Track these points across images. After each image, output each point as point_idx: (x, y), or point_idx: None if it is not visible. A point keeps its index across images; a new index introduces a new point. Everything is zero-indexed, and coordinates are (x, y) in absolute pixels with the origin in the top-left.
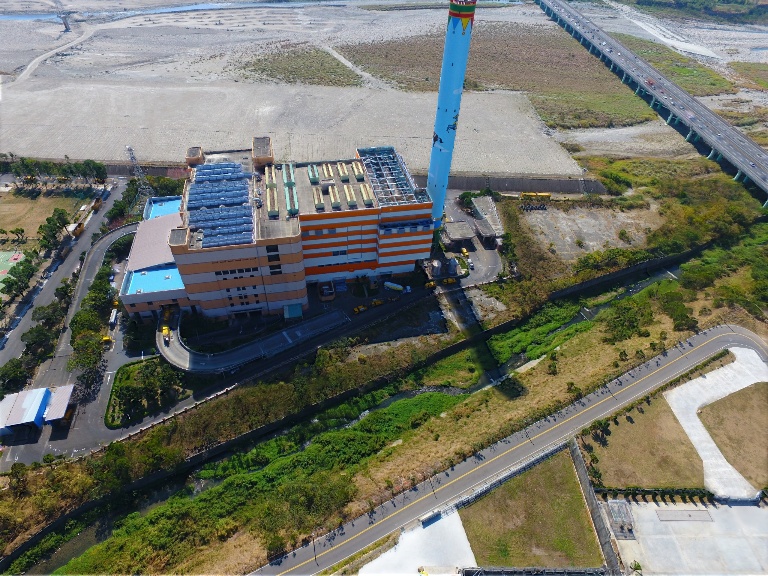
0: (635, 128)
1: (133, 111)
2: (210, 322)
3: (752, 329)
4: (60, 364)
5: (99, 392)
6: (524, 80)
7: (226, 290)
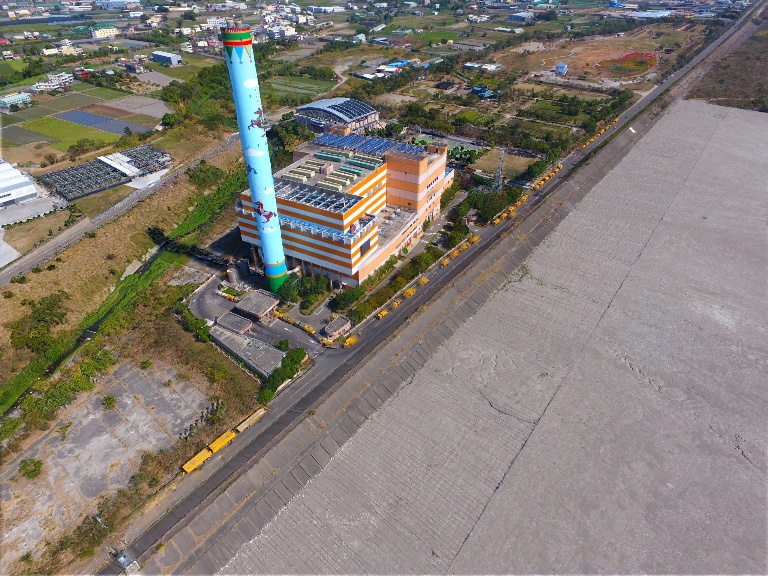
0: None
1: (721, 223)
2: None
3: None
4: None
5: None
6: None
7: None
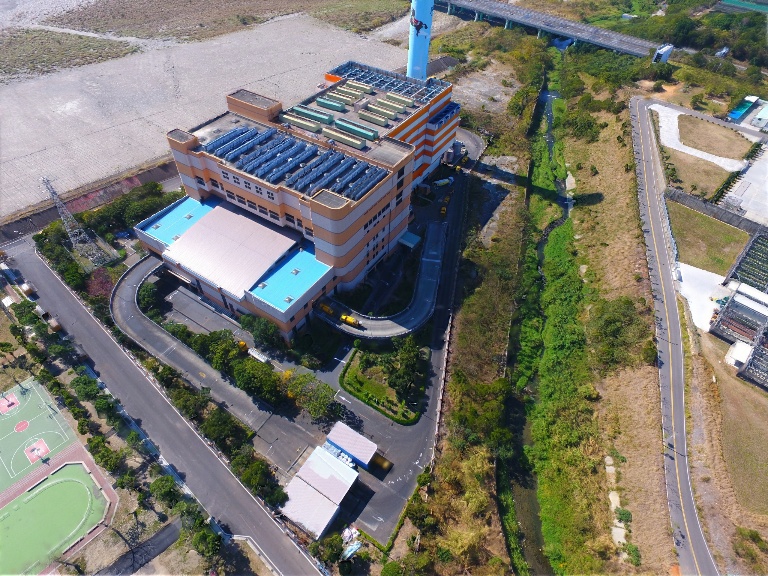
0: (409, 16)
1: None
2: (360, 292)
3: (642, 94)
4: (274, 431)
5: (355, 414)
6: (286, 3)
7: (366, 246)
